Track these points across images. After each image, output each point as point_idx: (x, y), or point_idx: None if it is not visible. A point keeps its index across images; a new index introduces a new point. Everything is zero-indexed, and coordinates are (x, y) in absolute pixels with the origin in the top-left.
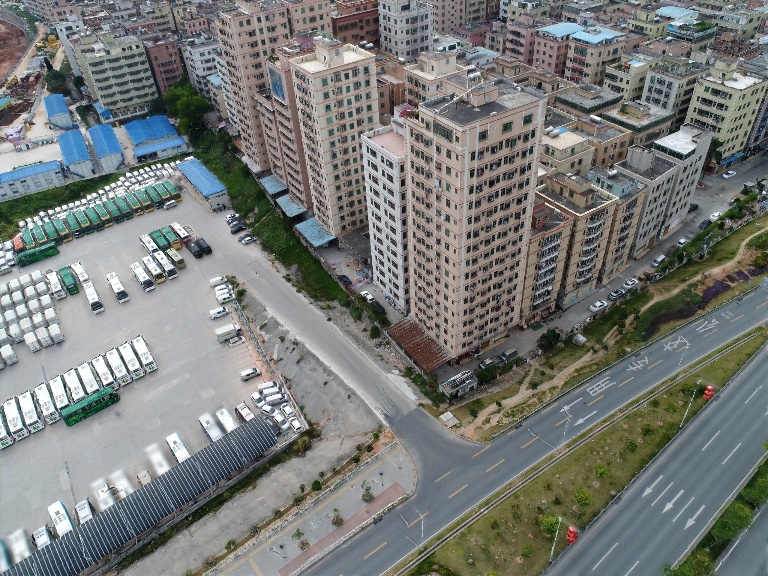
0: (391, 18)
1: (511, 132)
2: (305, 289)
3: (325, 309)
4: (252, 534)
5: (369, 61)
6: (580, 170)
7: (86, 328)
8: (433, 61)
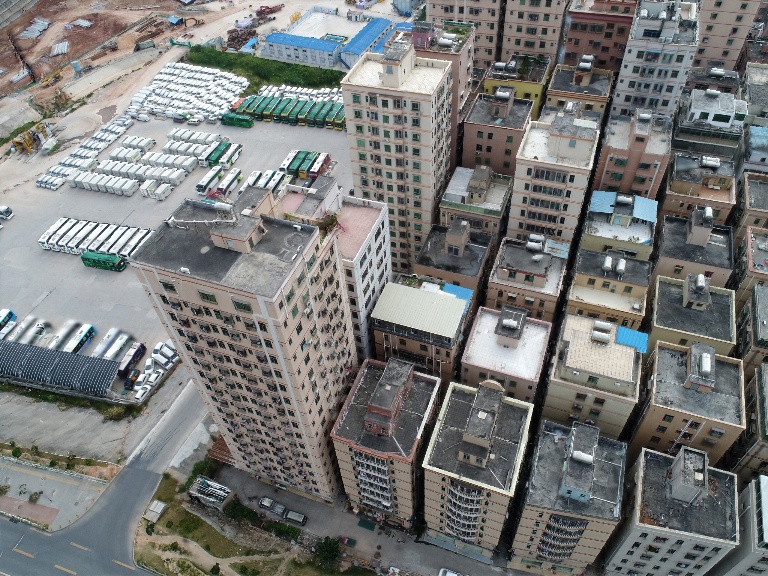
0: None
1: None
2: None
3: None
4: None
5: (422, 97)
6: (600, 411)
7: None
8: None
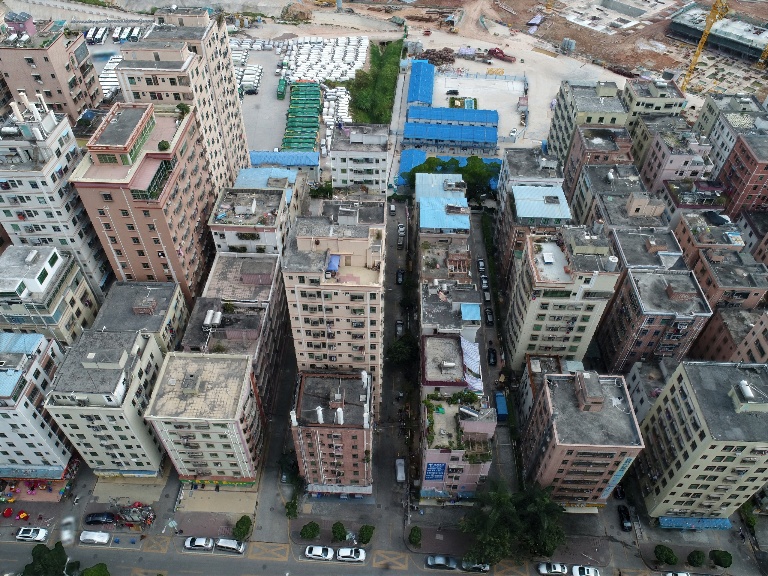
0: None
1: None
2: None
3: None
4: None
5: None
6: None
7: None
8: None
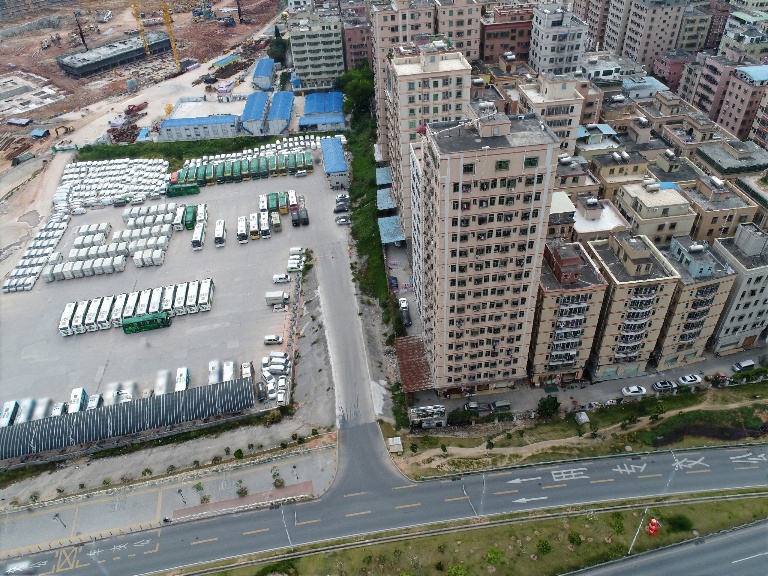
0: (540, 32)
1: (508, 171)
2: (361, 280)
3: (364, 304)
4: (167, 471)
5: (464, 73)
6: (672, 235)
7: (182, 260)
8: (547, 84)
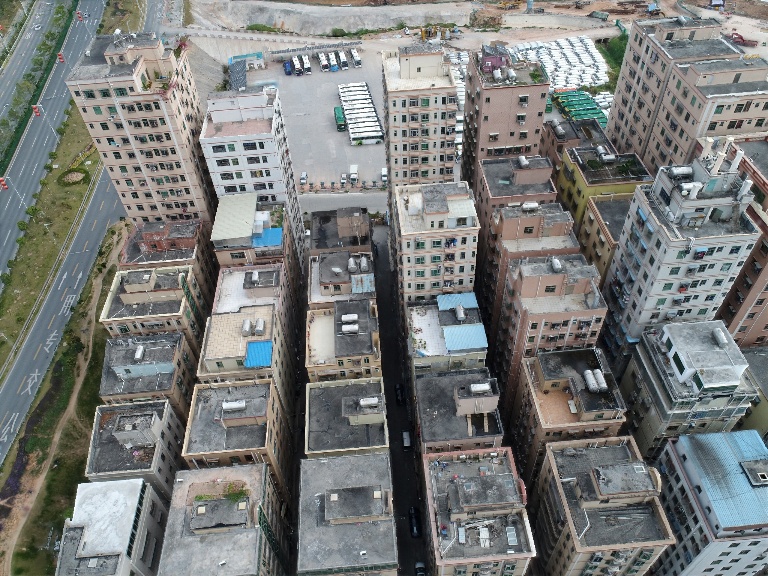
0: None
1: None
2: None
3: None
4: None
5: None
6: None
7: None
8: None
